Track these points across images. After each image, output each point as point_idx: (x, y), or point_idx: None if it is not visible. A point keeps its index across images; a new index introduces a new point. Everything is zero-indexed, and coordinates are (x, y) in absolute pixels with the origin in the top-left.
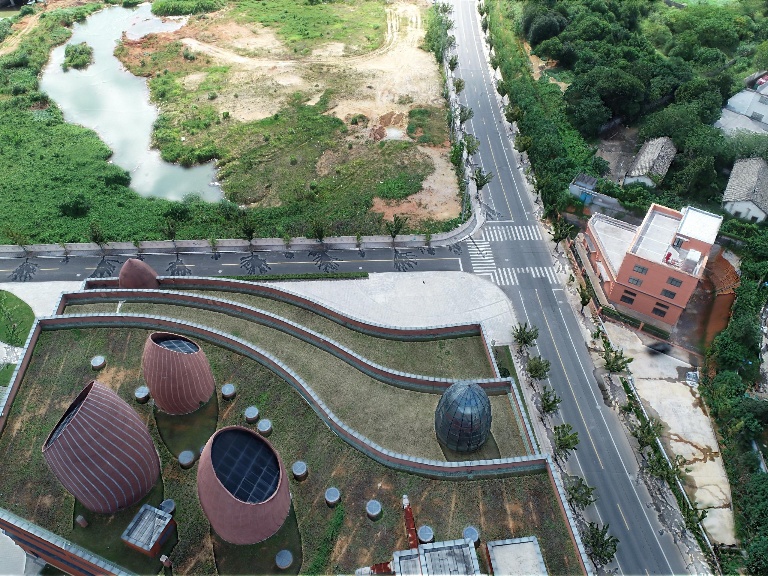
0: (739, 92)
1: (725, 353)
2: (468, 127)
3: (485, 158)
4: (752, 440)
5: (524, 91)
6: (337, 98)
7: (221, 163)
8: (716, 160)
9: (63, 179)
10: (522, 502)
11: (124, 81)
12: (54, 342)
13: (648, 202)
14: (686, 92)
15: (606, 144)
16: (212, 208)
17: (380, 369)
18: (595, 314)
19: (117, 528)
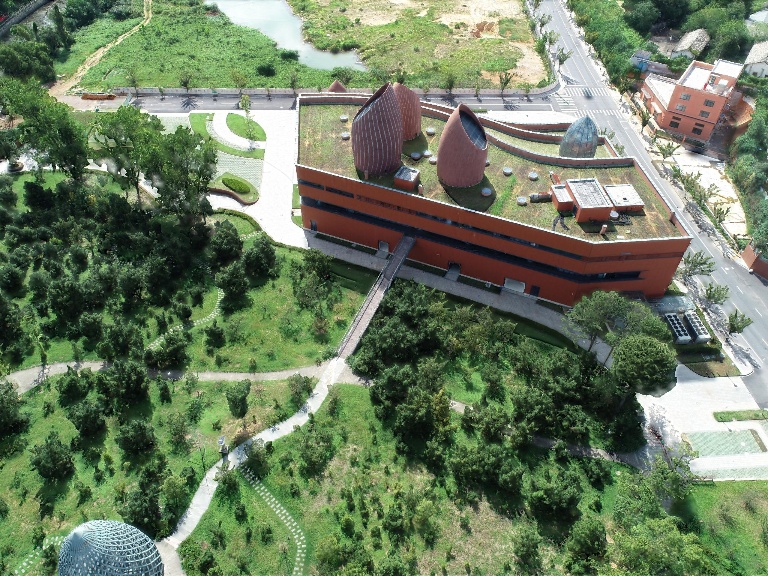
0: (759, 11)
1: (743, 144)
2: None
3: None
4: (760, 187)
5: (588, 7)
6: (440, 12)
7: (361, 50)
8: (740, 43)
9: (250, 55)
10: (620, 177)
11: (268, 1)
12: (311, 110)
13: None
14: (717, 3)
15: (655, 38)
16: (365, 73)
17: (520, 130)
18: (651, 134)
19: (385, 180)
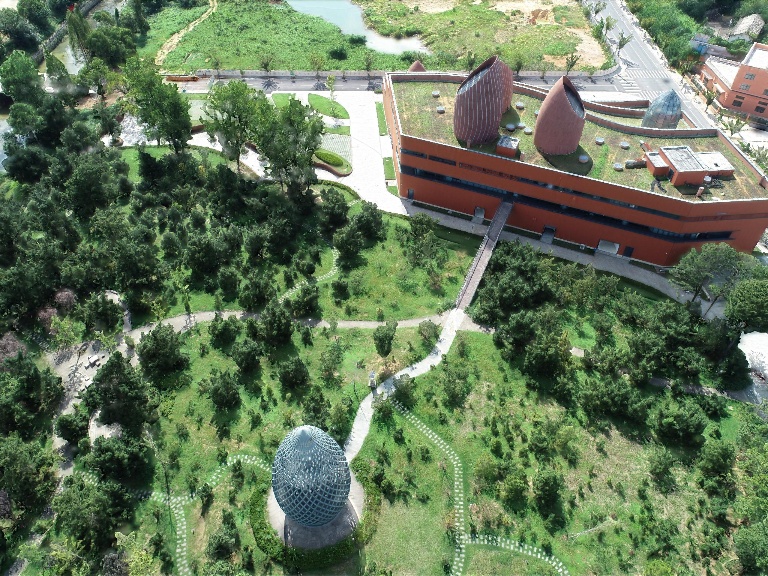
0: None
1: None
2: (600, 18)
3: (617, 35)
4: None
5: None
6: (494, 1)
7: (424, 36)
8: None
9: None
10: (706, 146)
11: None
12: (402, 87)
13: (748, 49)
14: None
15: (709, 23)
16: (432, 57)
17: (601, 105)
18: (715, 113)
19: (486, 149)
